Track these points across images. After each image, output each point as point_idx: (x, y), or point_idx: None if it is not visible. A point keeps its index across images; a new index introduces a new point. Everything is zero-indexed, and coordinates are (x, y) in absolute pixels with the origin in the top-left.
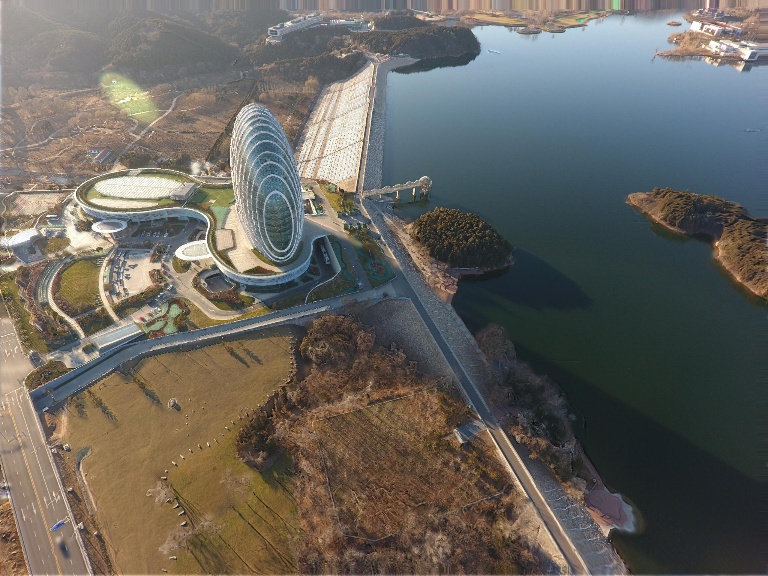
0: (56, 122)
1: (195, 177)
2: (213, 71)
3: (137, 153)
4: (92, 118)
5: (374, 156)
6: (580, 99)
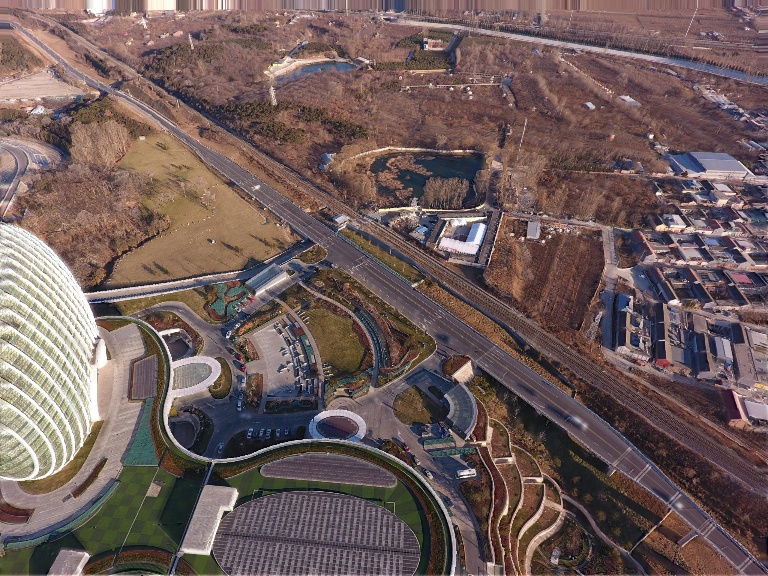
0: None
1: None
2: None
3: None
4: None
5: None
6: None
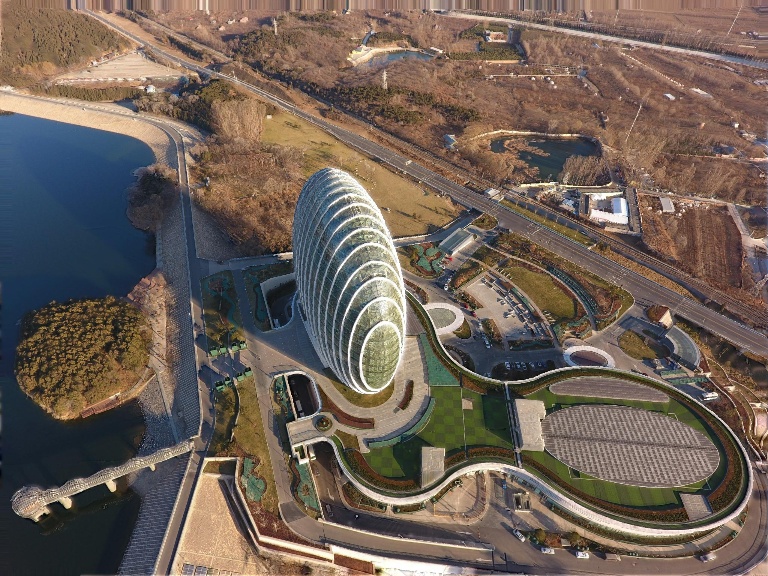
0: None
1: None
2: None
3: None
4: None
5: None
6: None
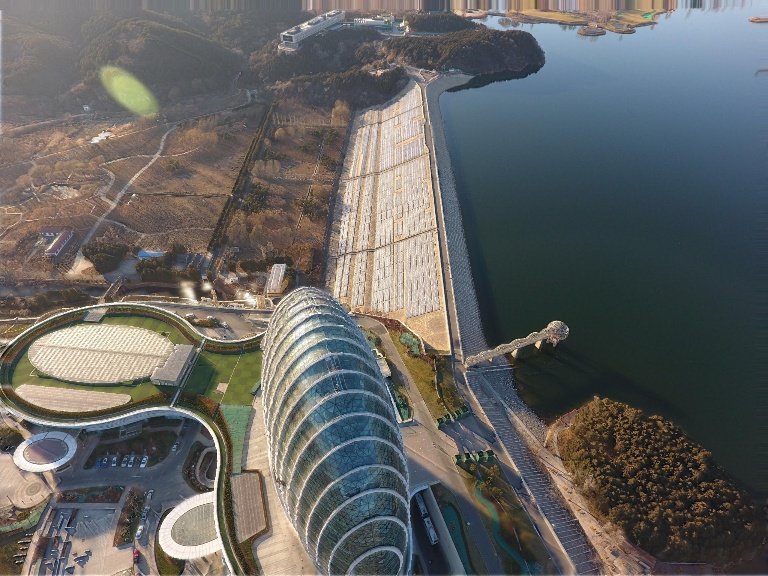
0: (2, 177)
1: (193, 307)
2: (213, 90)
3: (108, 245)
4: (52, 171)
5: (458, 261)
6: (718, 151)
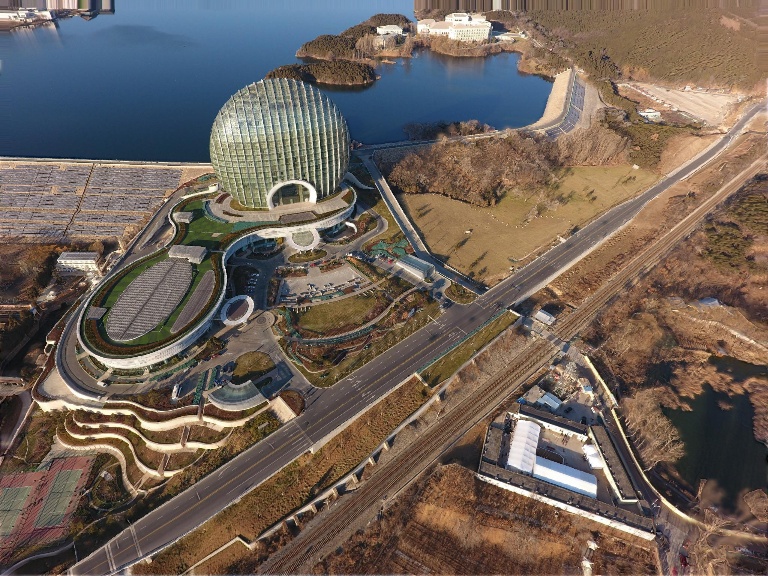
0: None
1: None
2: None
3: None
4: None
5: None
6: (99, 67)
